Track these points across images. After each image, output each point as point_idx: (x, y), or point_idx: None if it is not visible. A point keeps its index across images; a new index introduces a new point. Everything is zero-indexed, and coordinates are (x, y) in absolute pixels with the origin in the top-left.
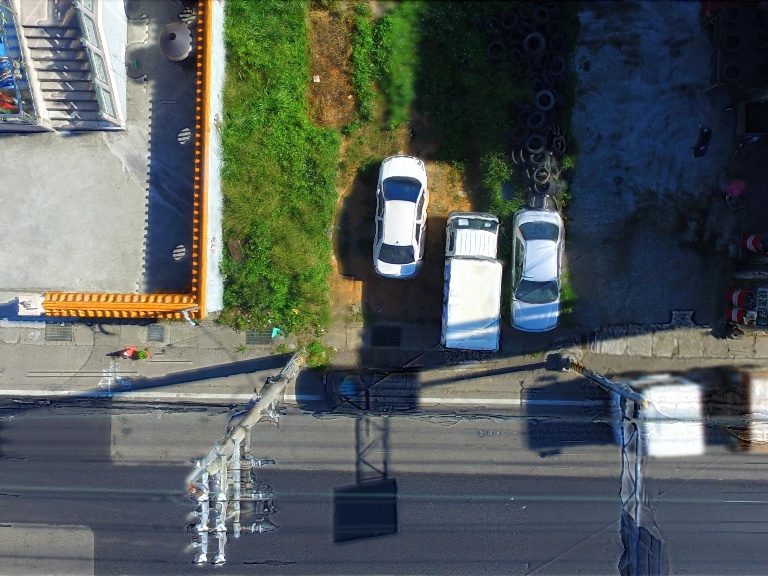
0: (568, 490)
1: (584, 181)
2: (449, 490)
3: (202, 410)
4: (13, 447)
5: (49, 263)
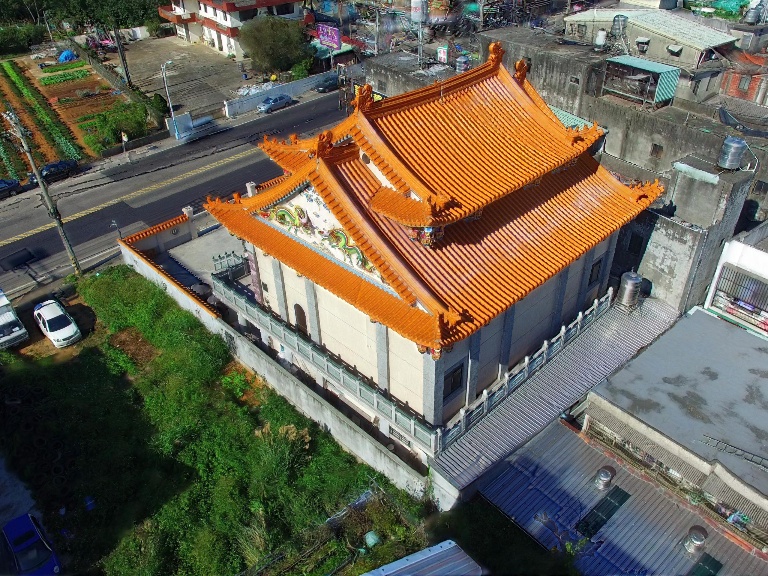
0: None
1: None
2: None
3: None
4: (184, 207)
5: (213, 239)
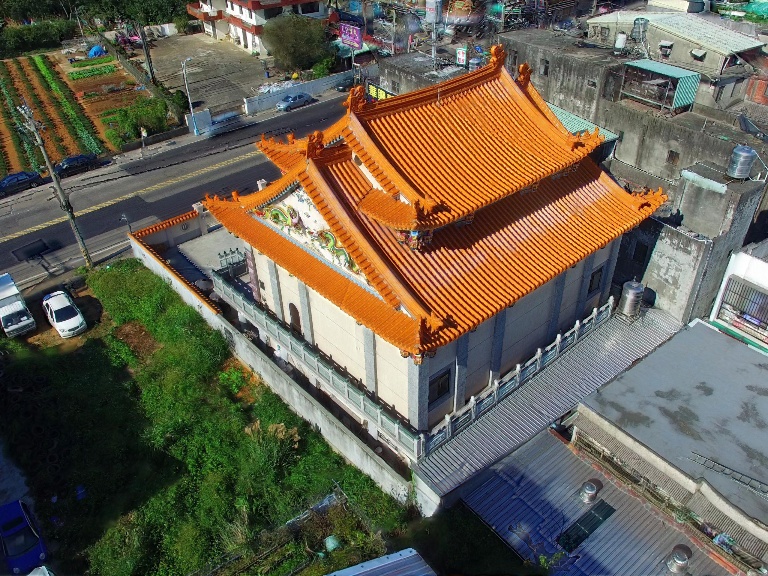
0: None
1: None
2: None
3: None
4: None
5: (222, 235)
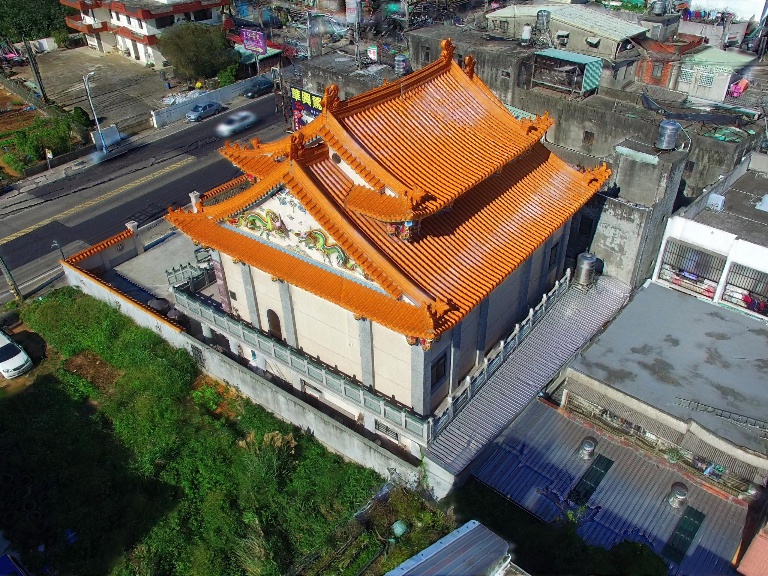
0: None
1: None
2: None
3: (4, 207)
4: (124, 222)
5: (160, 253)
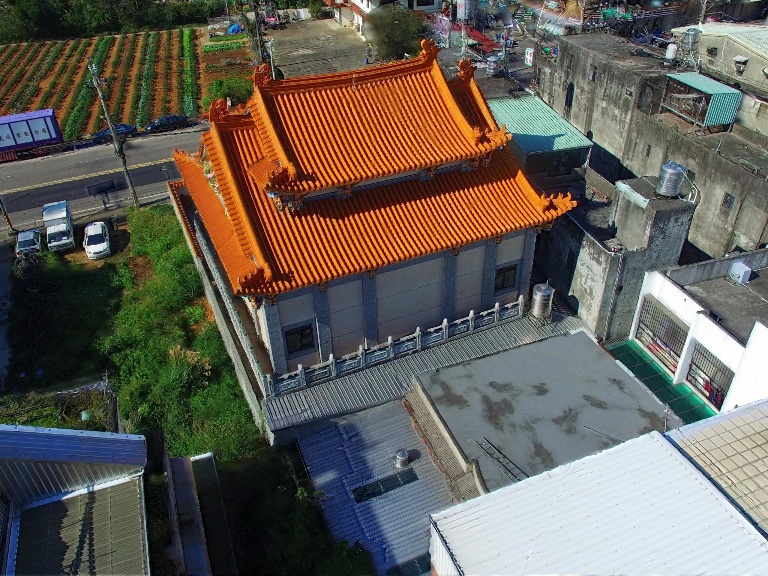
0: (13, 210)
1: (6, 274)
2: None
3: None
4: None
5: None
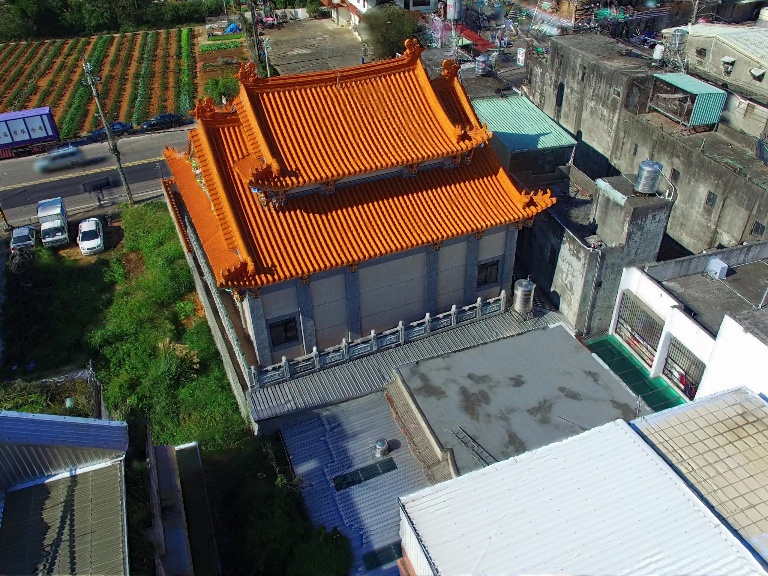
0: (9, 206)
1: (0, 269)
2: (62, 195)
3: None
4: None
5: None
